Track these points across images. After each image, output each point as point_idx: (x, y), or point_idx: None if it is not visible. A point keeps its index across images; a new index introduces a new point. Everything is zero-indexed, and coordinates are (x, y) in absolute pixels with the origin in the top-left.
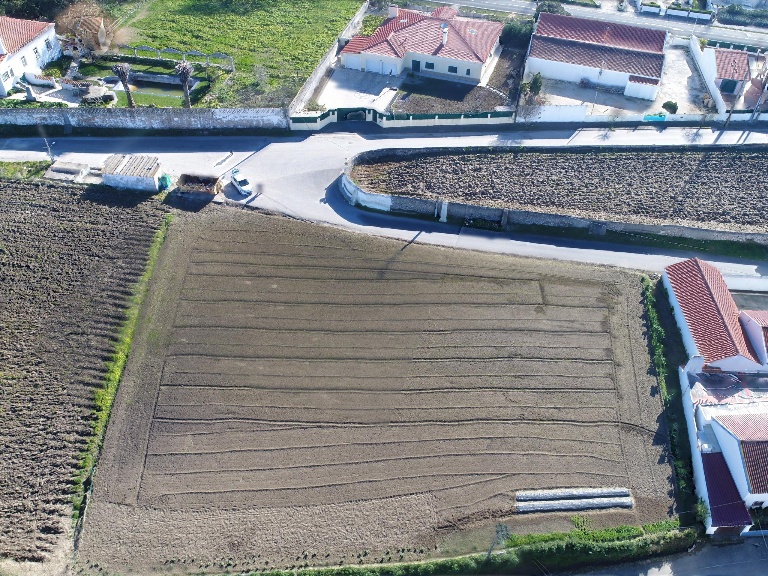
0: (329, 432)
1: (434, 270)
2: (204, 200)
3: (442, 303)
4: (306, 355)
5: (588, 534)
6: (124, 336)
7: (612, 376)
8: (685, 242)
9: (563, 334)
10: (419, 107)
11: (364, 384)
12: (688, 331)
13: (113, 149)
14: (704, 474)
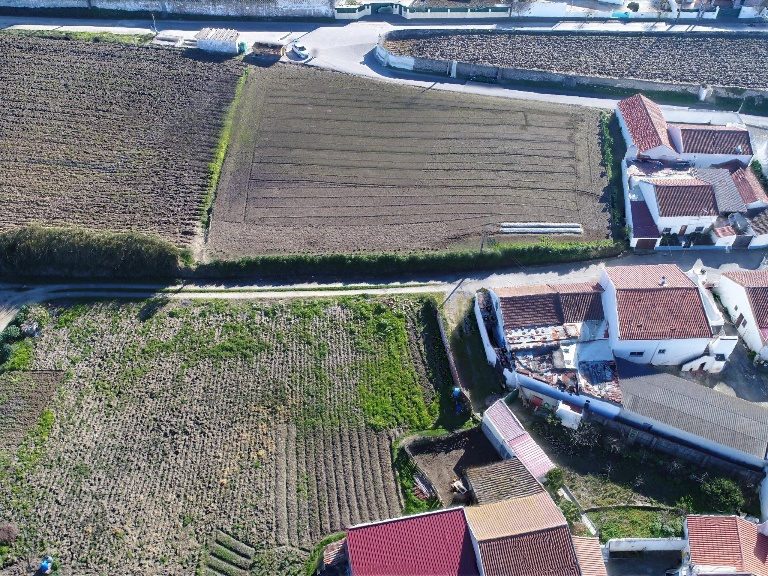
0: (372, 189)
1: (446, 104)
2: (273, 60)
3: (452, 123)
4: (354, 149)
5: (550, 245)
6: (224, 135)
7: (573, 166)
8: (636, 92)
9: (540, 142)
10: (435, 6)
11: (396, 165)
12: (630, 137)
13: (200, 28)
14: (631, 211)
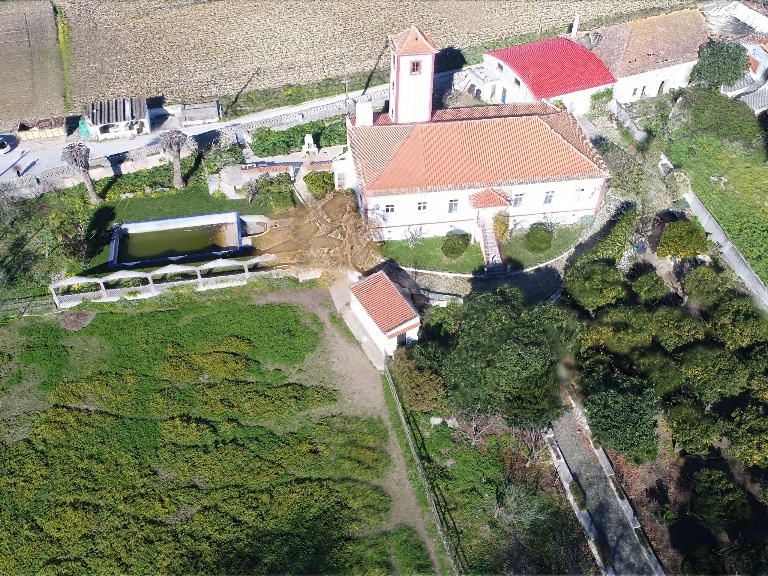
0: None
1: None
2: None
3: None
4: None
5: None
6: (66, 47)
7: None
8: None
9: None
10: None
11: None
12: None
13: None
14: None
